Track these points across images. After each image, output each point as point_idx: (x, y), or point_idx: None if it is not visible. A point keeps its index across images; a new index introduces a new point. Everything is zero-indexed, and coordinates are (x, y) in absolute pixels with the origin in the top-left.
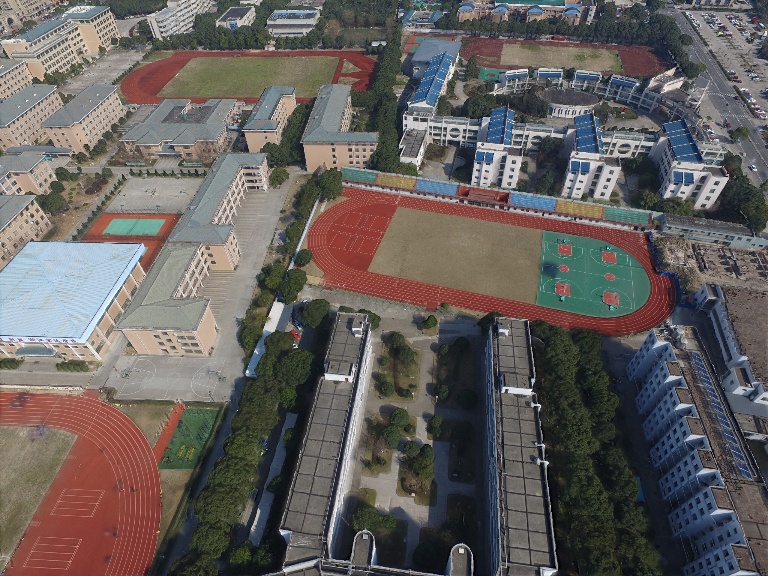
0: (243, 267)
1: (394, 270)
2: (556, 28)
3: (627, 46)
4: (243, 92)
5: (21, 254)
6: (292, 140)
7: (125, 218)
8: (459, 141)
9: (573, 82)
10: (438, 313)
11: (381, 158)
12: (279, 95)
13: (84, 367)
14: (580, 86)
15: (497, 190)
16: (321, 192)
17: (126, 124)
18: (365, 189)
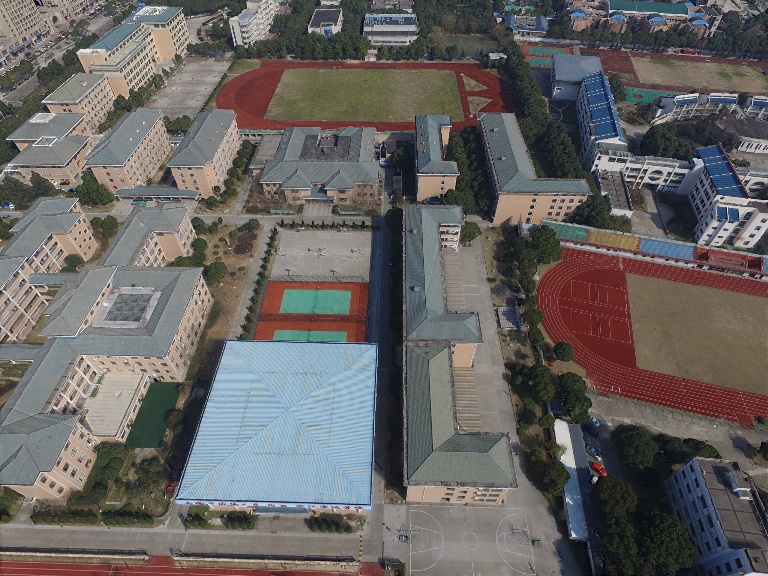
0: (480, 362)
1: (670, 366)
2: (687, 40)
3: (767, 62)
4: (365, 114)
5: (226, 361)
6: (473, 185)
7: (299, 289)
8: (657, 184)
9: (748, 109)
10: (759, 432)
11: (594, 211)
12: (437, 126)
13: (351, 529)
14: (755, 113)
15: (744, 254)
16: (538, 256)
17: (257, 159)
18: (574, 248)
